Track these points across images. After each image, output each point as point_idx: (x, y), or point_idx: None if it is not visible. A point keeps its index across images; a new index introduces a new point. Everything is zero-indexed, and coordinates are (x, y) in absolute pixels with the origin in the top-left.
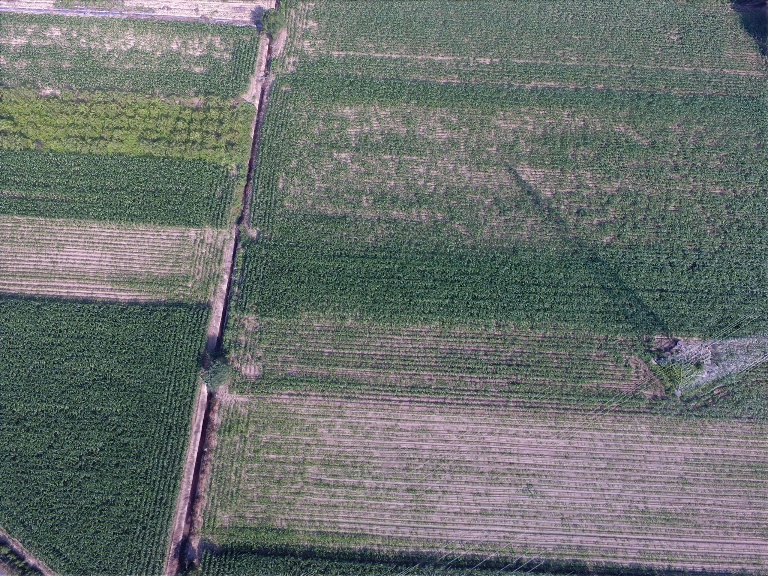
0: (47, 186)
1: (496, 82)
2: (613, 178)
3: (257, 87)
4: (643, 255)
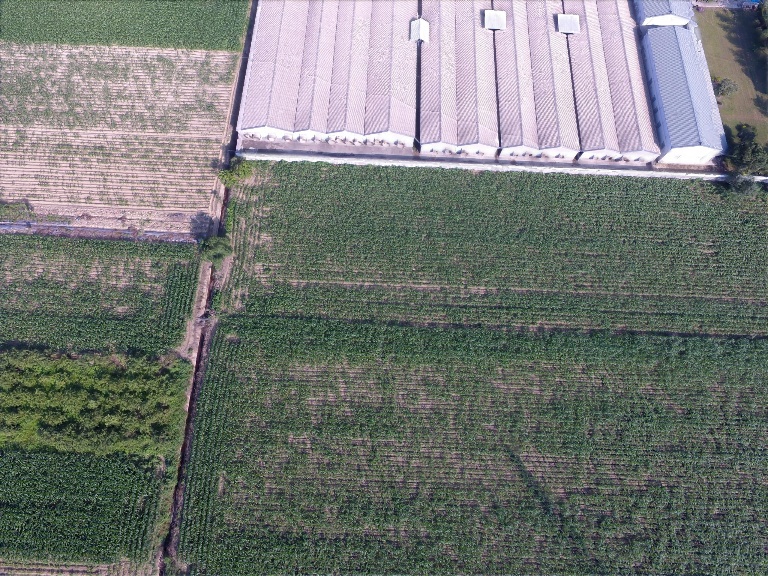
0: None
1: (493, 323)
2: (641, 469)
3: (195, 333)
4: None
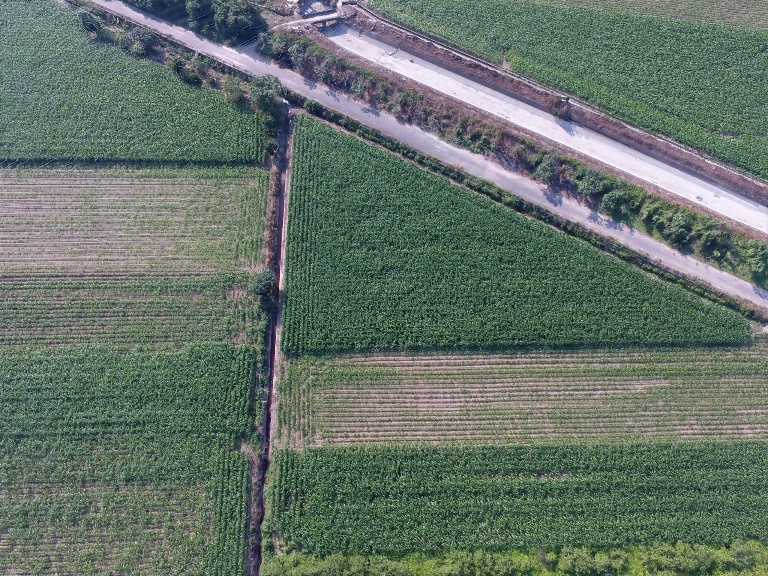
0: (509, 492)
1: None
2: None
3: None
4: None
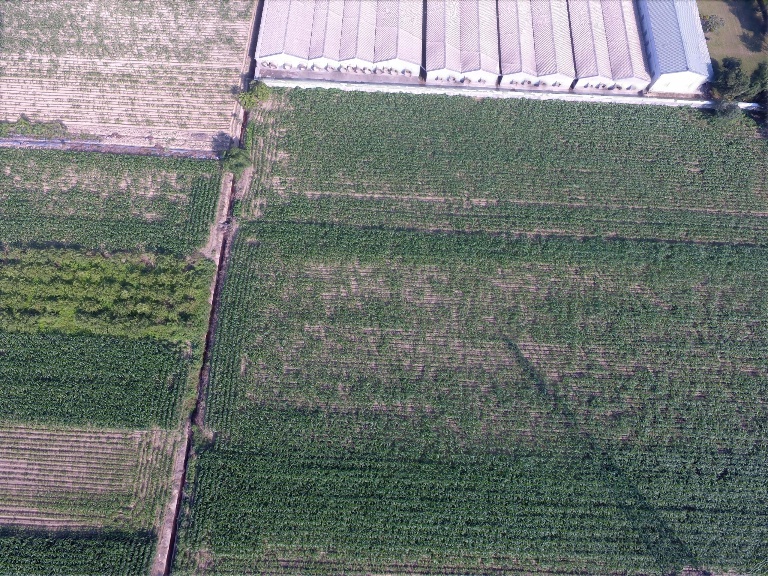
0: None
1: (493, 230)
2: (629, 356)
3: (218, 237)
4: (666, 460)
